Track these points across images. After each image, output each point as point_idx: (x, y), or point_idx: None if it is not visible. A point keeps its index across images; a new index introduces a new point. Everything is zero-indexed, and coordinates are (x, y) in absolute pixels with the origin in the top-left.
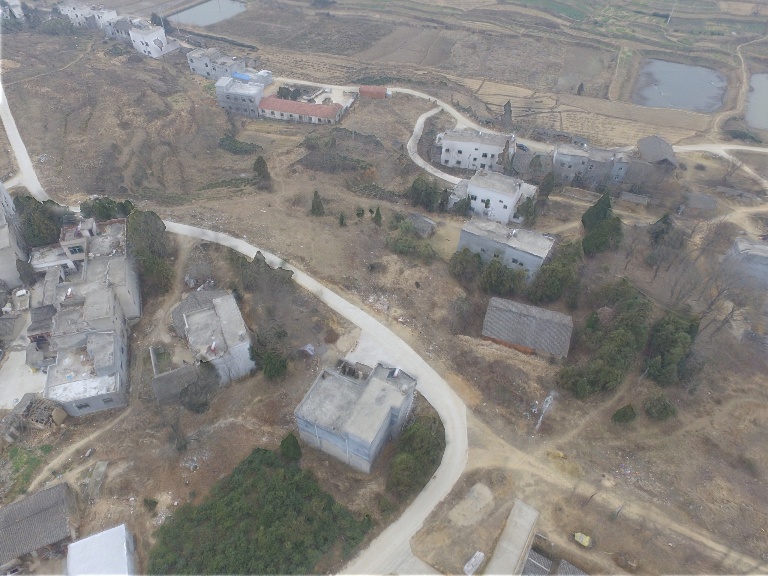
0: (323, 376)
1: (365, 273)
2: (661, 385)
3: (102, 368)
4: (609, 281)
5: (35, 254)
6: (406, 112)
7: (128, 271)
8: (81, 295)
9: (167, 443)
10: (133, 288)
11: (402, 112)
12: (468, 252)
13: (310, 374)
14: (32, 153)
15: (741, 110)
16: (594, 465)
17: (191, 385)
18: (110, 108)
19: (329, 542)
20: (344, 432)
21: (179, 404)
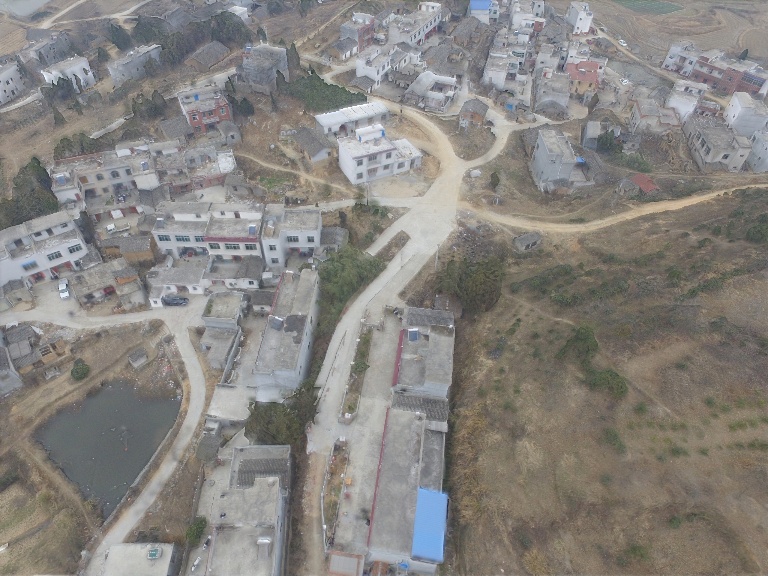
0: None
1: None
2: None
3: None
4: (189, 29)
5: None
6: None
7: None
8: None
9: (272, 117)
10: None
11: None
12: None
13: None
14: None
15: (8, 11)
16: None
17: (244, 99)
18: None
19: None
20: None
21: (243, 130)
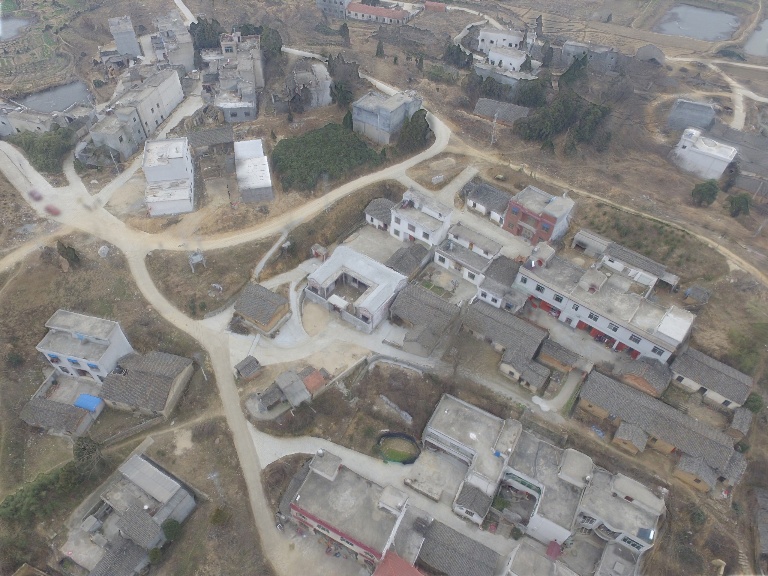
0: (370, 94)
1: (405, 83)
2: (578, 141)
3: (246, 95)
4: (563, 92)
5: (203, 53)
6: (459, 21)
7: (262, 56)
8: None
9: (282, 120)
10: (262, 70)
11: (456, 20)
12: (474, 72)
13: None
14: (193, 12)
15: (742, 40)
16: (519, 160)
17: None
18: None
19: (363, 159)
20: (378, 108)
21: None
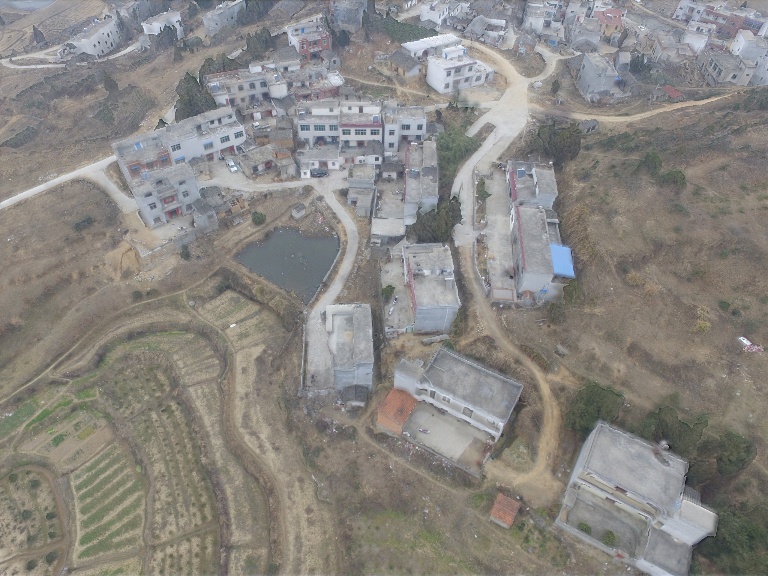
0: (337, 6)
1: None
2: None
3: None
4: None
5: None
6: (3, 73)
7: None
8: None
9: (365, 46)
10: None
11: (2, 74)
12: None
13: None
14: (34, 185)
15: None
16: None
17: None
18: None
19: None
20: None
21: (341, 58)
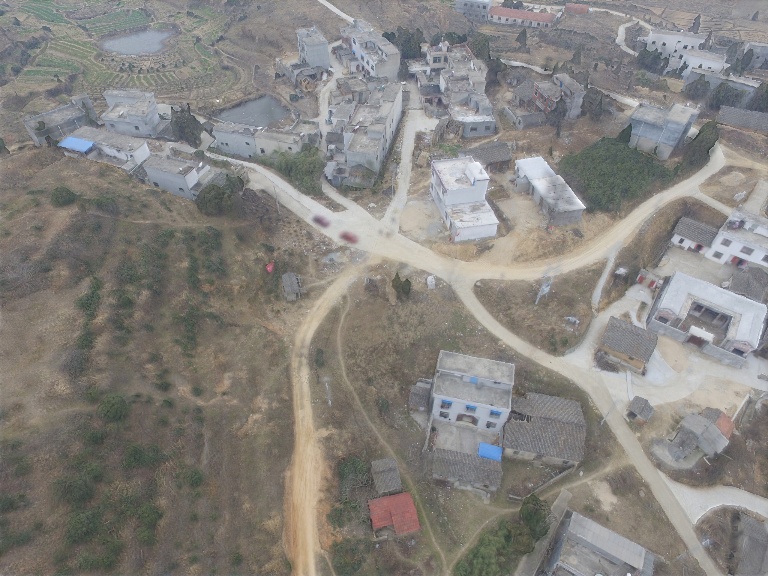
0: None
1: None
2: None
3: (486, 108)
4: None
5: None
6: (608, 22)
7: None
8: (458, 76)
9: (545, 135)
10: None
11: (605, 22)
12: (703, 77)
13: (612, 123)
14: None
15: None
16: None
17: None
18: (393, 1)
19: (655, 176)
20: (667, 121)
21: None
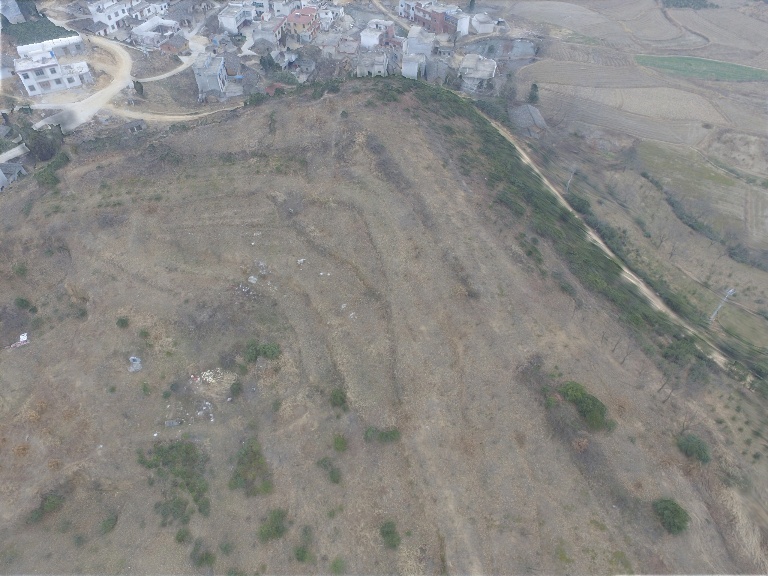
0: None
1: None
2: None
3: None
4: None
5: None
6: None
7: None
8: None
9: None
10: None
11: None
12: None
13: None
14: None
15: None
16: None
17: None
18: None
19: None
20: None
21: None
